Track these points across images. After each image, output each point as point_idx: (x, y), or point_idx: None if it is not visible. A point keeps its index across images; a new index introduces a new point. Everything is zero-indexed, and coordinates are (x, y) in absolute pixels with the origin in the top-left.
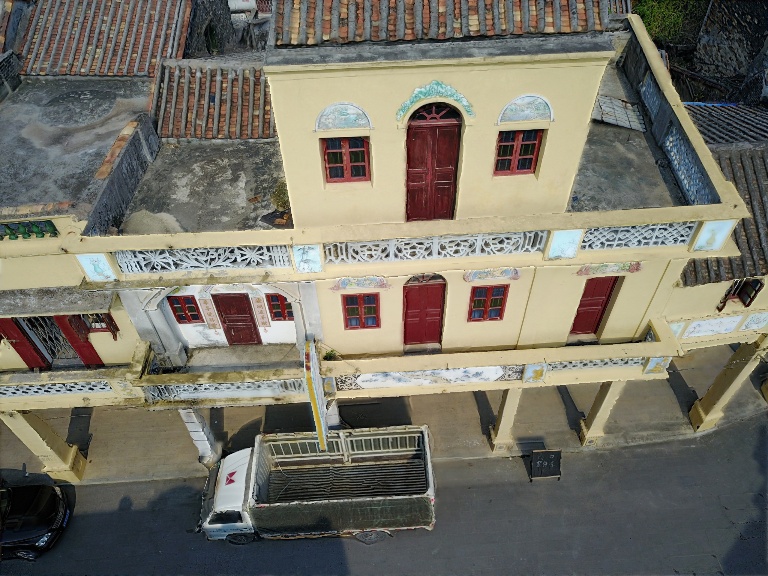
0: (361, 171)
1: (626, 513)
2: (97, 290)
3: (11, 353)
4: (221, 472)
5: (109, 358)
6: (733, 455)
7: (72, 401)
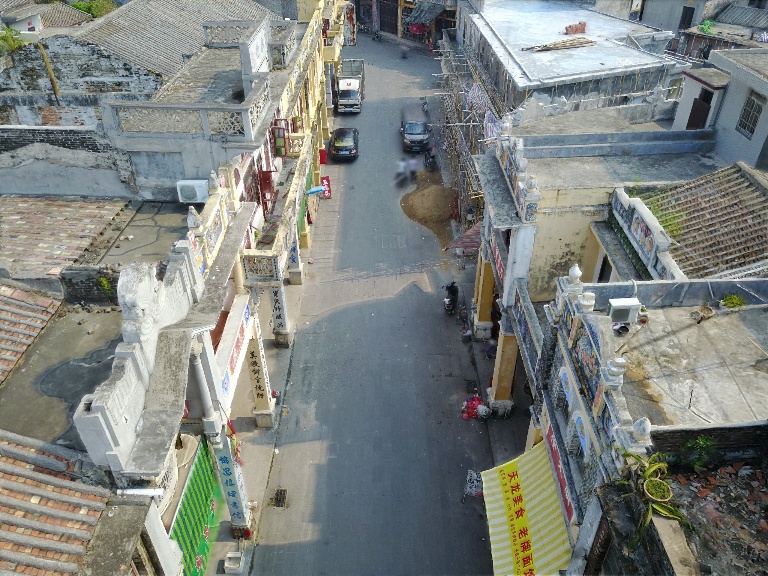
0: None
1: None
2: None
3: None
4: (345, 89)
5: None
6: None
7: None
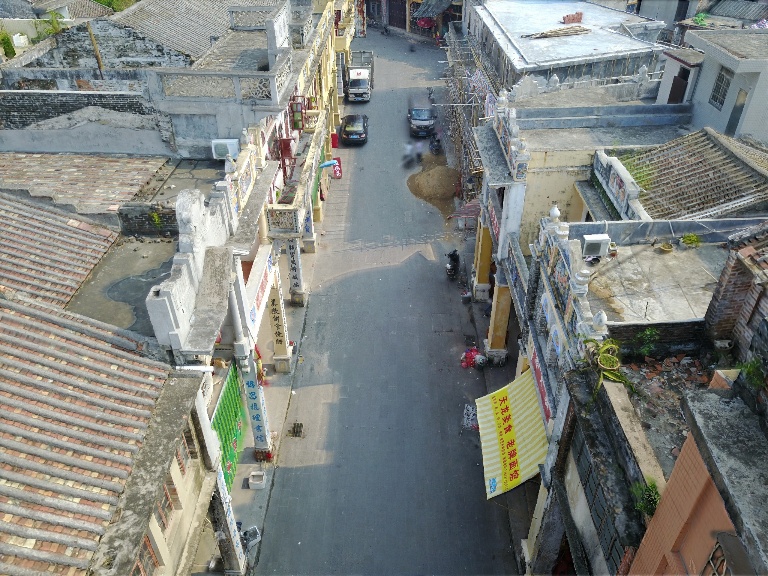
0: None
1: None
2: None
3: None
4: (355, 78)
5: None
6: None
7: (349, 41)
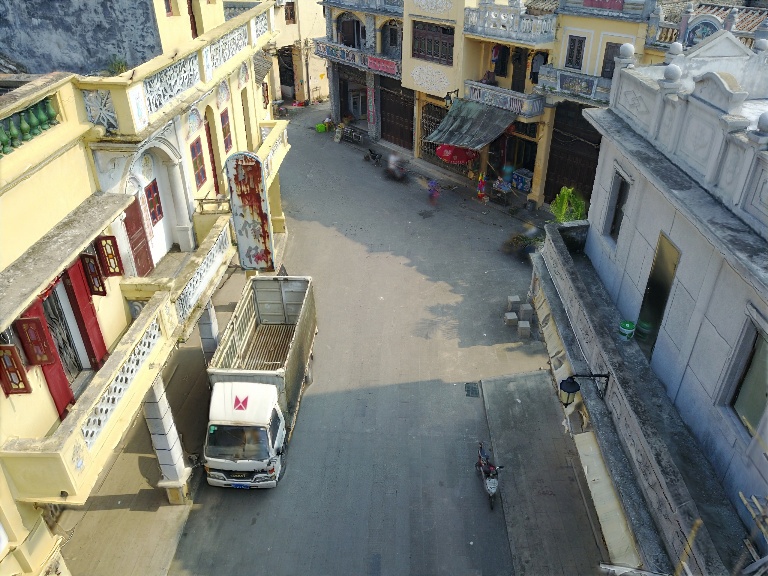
0: (167, 8)
1: (327, 266)
2: (144, 142)
3: (41, 398)
4: (226, 421)
5: (108, 337)
6: (305, 227)
7: (146, 377)
